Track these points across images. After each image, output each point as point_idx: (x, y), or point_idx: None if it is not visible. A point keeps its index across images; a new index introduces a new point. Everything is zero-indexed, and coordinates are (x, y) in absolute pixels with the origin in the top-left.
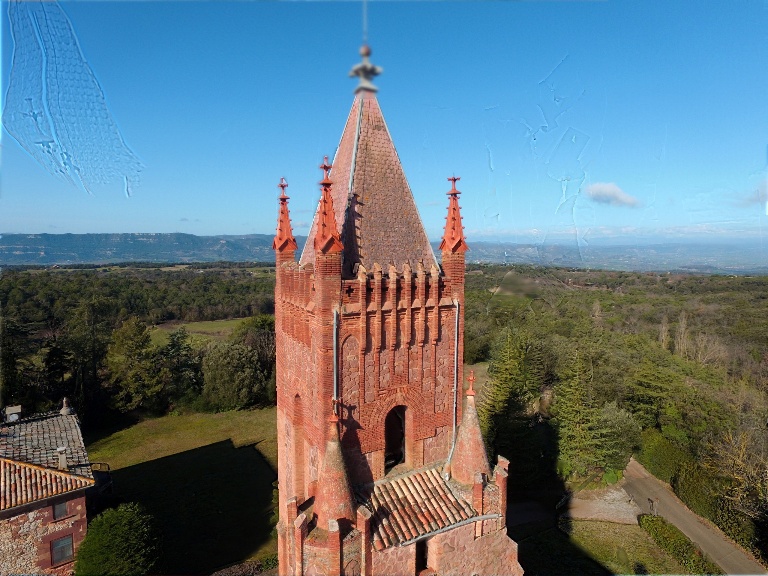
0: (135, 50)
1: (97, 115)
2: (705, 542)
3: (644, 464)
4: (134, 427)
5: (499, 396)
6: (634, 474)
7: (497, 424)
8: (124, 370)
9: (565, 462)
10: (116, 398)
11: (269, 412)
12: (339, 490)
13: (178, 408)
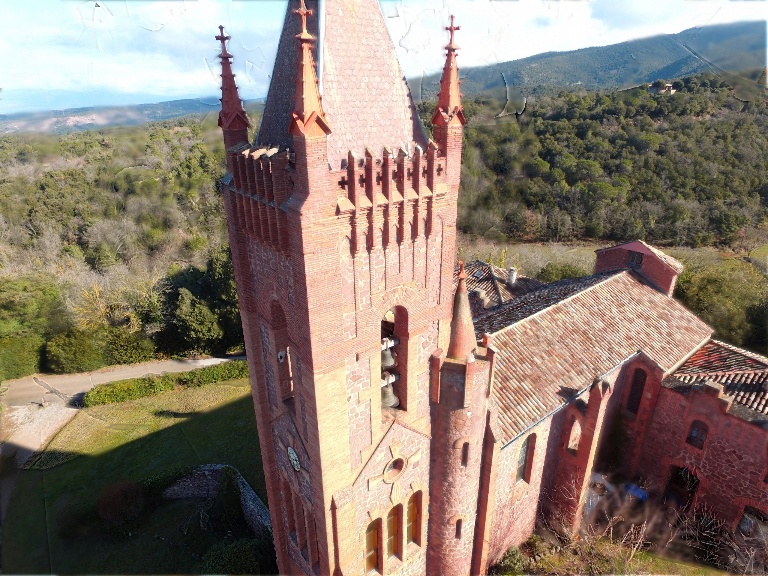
0: (759, 55)
1: (764, 75)
2: (129, 377)
3: None
4: None
5: None
6: None
7: None
8: None
9: None
10: None
11: None
12: None
13: None
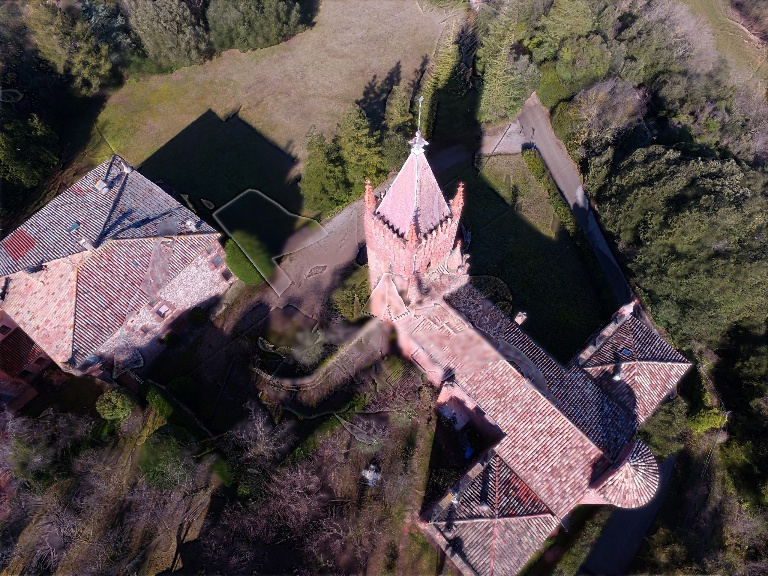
0: None
1: None
2: (555, 161)
3: (537, 93)
4: (108, 106)
5: (442, 76)
6: (528, 103)
7: (439, 98)
8: (67, 59)
9: (484, 114)
10: (76, 86)
11: (221, 63)
12: None
13: (132, 74)
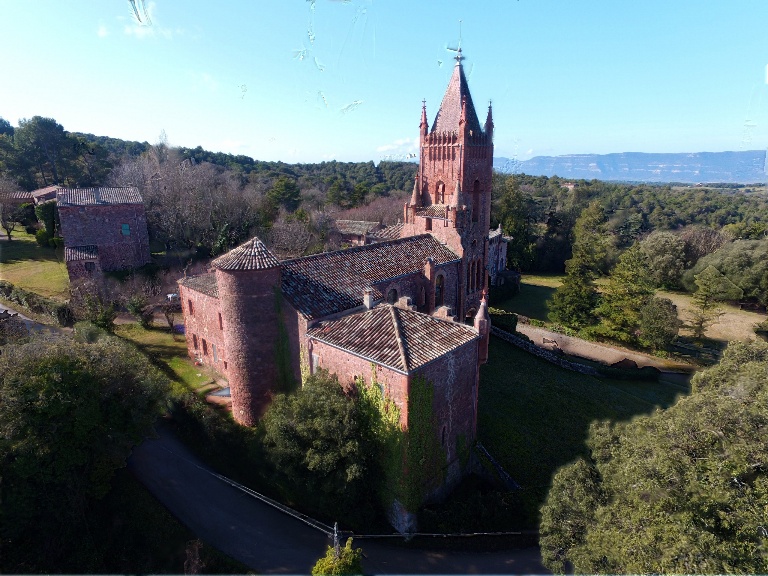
0: None
1: None
2: None
3: None
4: None
5: None
6: None
7: None
8: None
9: None
10: None
11: (681, 297)
12: (413, 197)
13: None
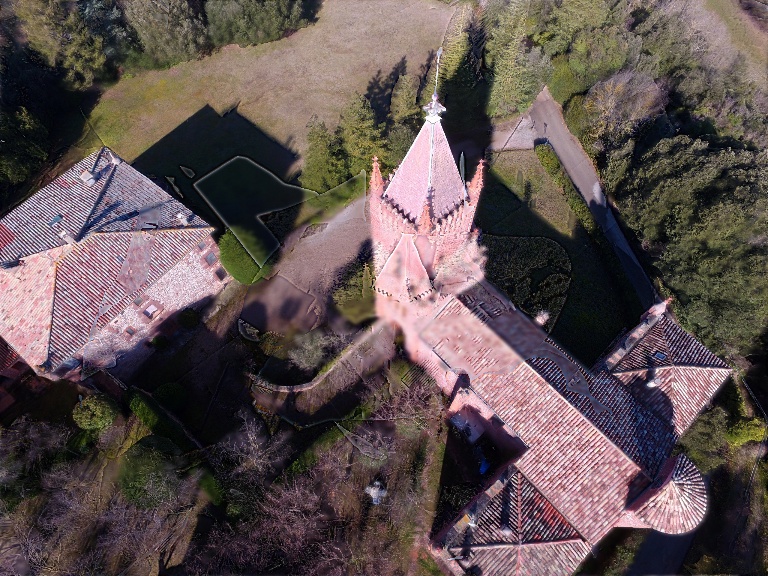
0: None
1: None
2: (569, 157)
3: (549, 88)
4: (102, 101)
5: (450, 66)
6: (540, 98)
7: (448, 90)
8: (59, 51)
9: (494, 108)
10: (69, 80)
11: (220, 59)
12: None
13: (128, 70)
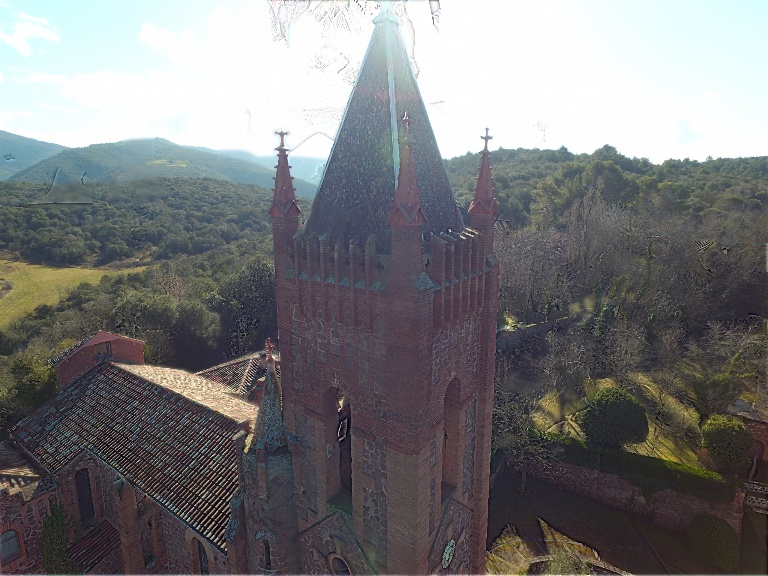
0: None
1: None
2: None
3: None
4: None
5: None
6: None
7: None
8: None
9: None
10: None
11: None
12: None
13: None
